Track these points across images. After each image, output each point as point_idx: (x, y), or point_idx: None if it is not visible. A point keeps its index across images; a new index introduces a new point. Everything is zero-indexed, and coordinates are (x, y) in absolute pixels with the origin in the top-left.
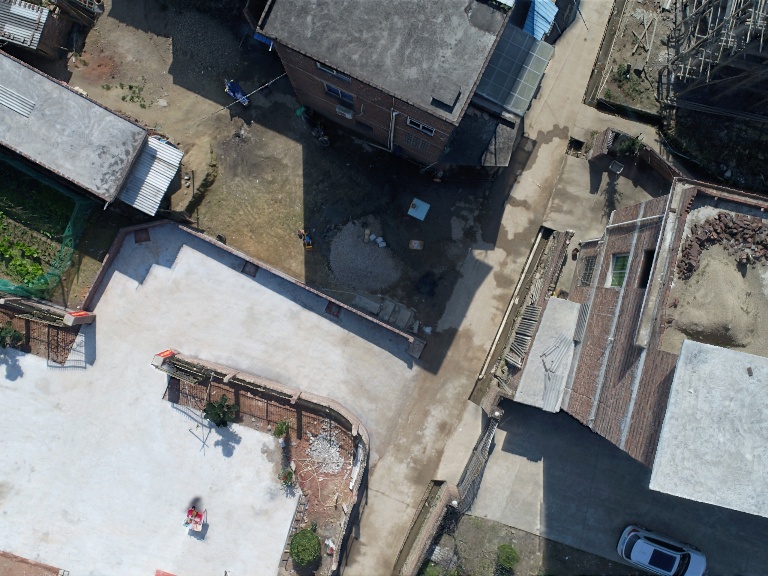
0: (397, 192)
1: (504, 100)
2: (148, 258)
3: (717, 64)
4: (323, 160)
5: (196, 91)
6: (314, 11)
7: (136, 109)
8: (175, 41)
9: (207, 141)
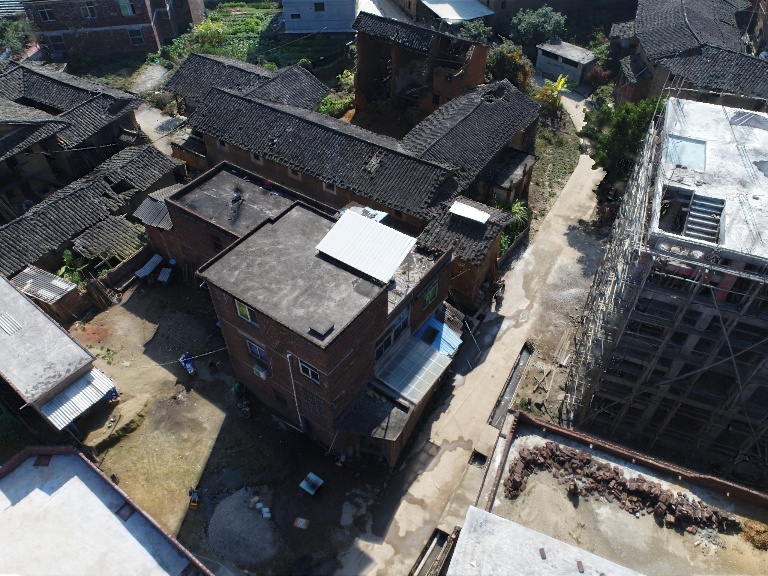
0: (298, 468)
1: (402, 389)
2: (36, 482)
3: (591, 387)
4: (240, 429)
5: (158, 361)
6: (242, 269)
7: (103, 364)
8: (160, 327)
9: (146, 397)
